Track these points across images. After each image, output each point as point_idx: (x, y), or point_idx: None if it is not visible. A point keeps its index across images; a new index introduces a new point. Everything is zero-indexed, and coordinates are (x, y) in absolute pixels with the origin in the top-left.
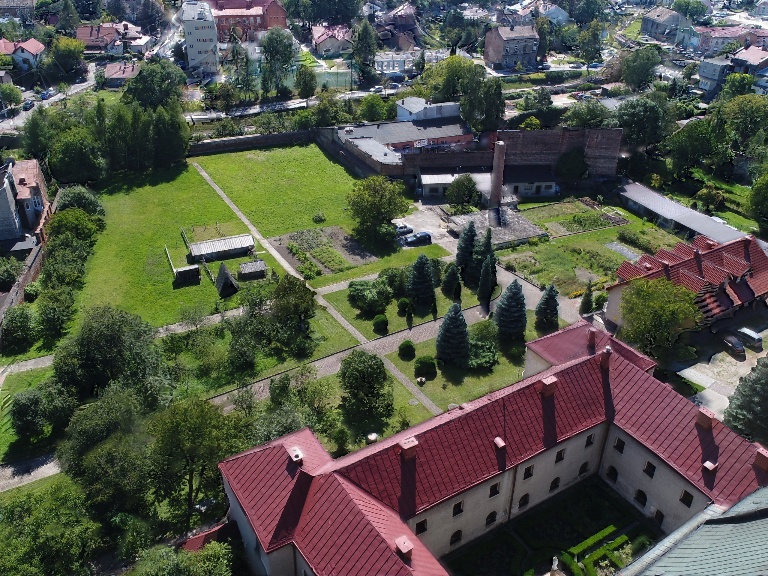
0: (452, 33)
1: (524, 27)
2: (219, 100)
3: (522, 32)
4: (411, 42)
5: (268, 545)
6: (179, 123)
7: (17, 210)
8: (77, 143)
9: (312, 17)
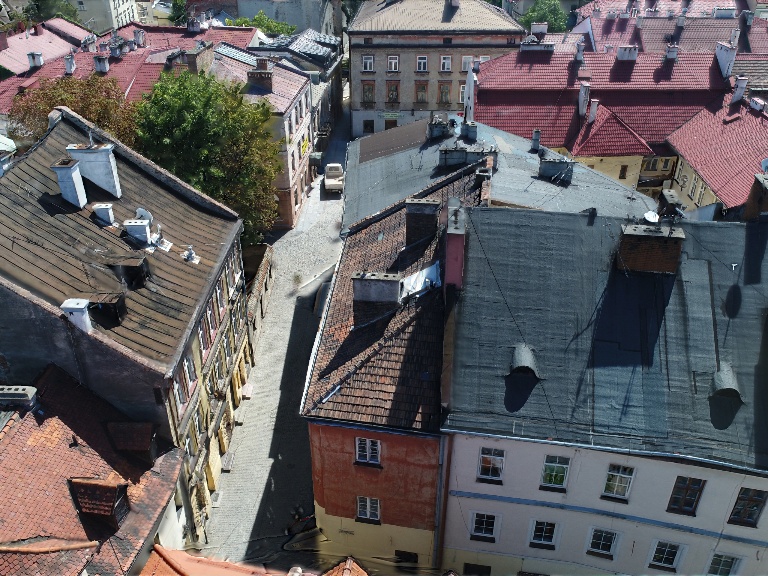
0: None
1: None
2: None
3: None
4: None
5: (512, 1)
6: None
7: None
8: None
9: None
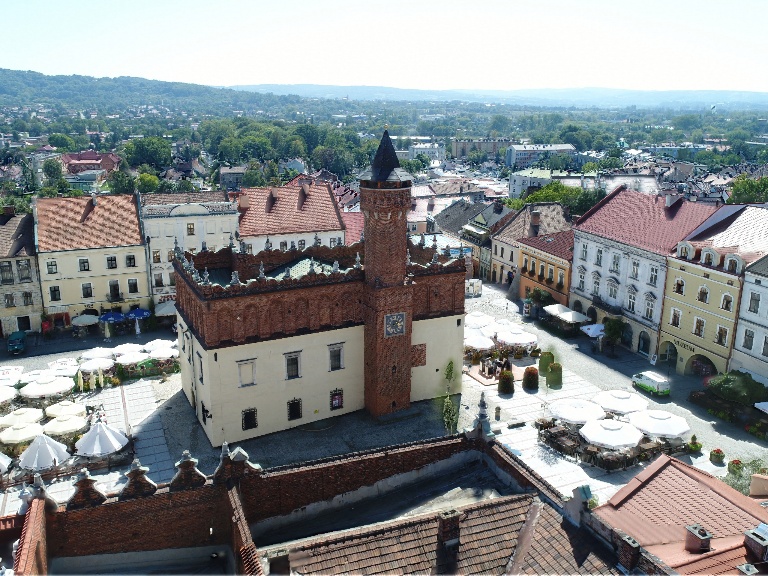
0: (212, 173)
1: (240, 167)
2: (5, 195)
3: (236, 170)
4: (173, 176)
5: None
6: None
7: None
8: None
9: (131, 164)
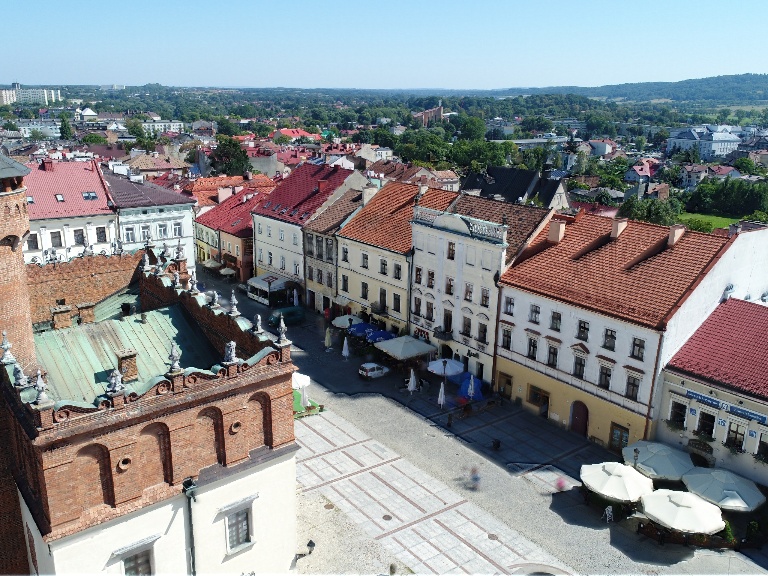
0: None
1: None
2: None
3: None
4: None
5: None
6: (761, 194)
7: (644, 197)
8: (700, 187)
9: None
